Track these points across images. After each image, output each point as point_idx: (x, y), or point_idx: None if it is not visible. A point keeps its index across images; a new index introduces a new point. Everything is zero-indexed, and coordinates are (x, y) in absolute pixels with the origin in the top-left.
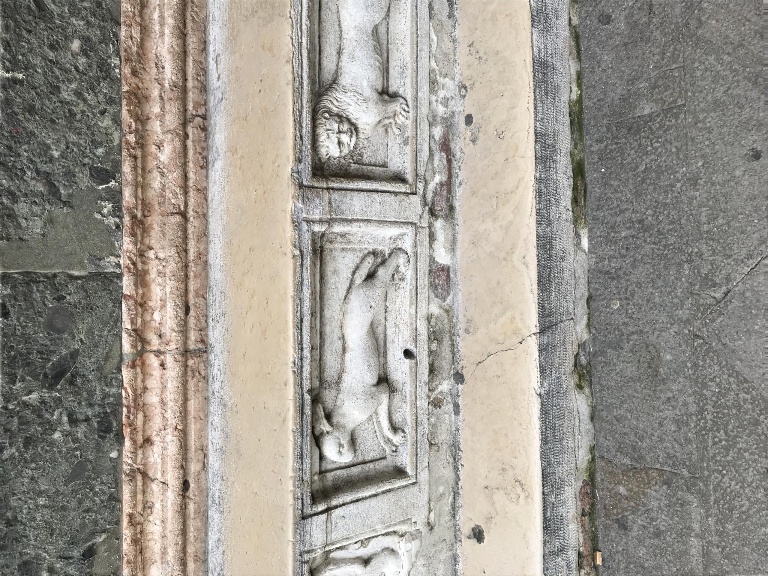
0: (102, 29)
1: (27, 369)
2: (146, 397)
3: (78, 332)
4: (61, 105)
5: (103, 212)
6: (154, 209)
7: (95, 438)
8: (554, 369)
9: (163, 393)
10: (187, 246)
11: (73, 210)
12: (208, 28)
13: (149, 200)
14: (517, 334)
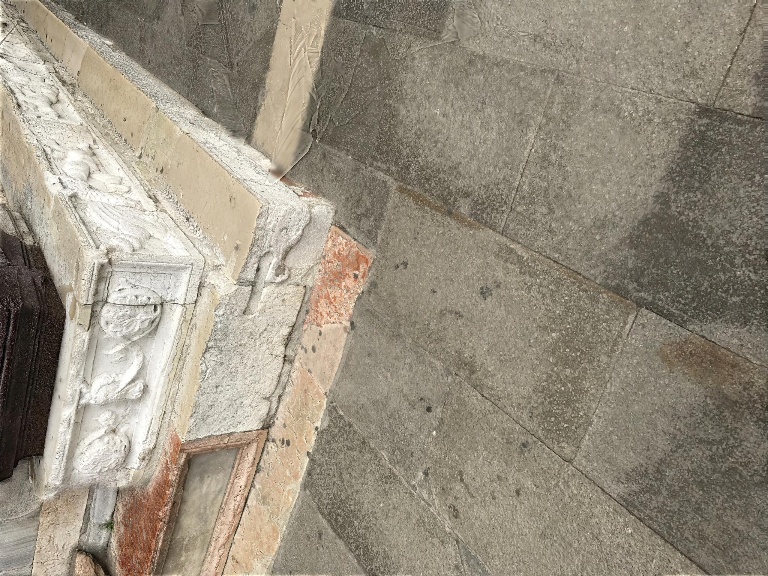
0: None
1: None
2: None
3: None
4: None
5: None
6: None
7: None
8: (50, 6)
9: None
10: None
11: None
12: None
13: None
14: (37, 8)
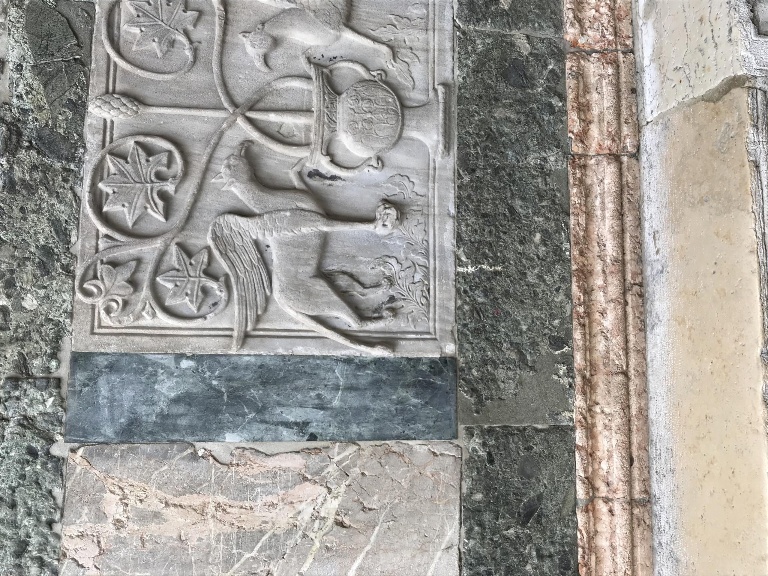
0: (556, 222)
1: (506, 508)
2: (596, 539)
3: (543, 478)
4: (528, 288)
5: (559, 373)
6: (599, 369)
7: (557, 573)
8: None
9: (612, 537)
10: (629, 402)
11: (536, 373)
12: (642, 207)
13: (595, 361)
14: None
